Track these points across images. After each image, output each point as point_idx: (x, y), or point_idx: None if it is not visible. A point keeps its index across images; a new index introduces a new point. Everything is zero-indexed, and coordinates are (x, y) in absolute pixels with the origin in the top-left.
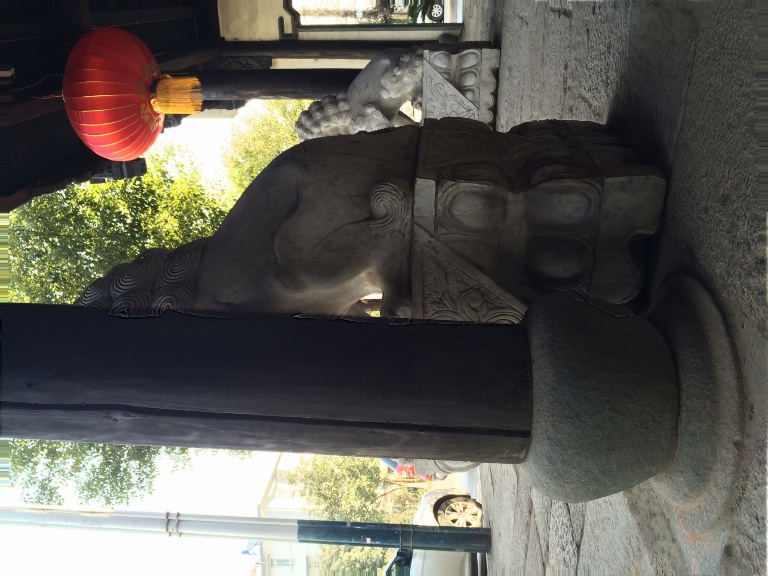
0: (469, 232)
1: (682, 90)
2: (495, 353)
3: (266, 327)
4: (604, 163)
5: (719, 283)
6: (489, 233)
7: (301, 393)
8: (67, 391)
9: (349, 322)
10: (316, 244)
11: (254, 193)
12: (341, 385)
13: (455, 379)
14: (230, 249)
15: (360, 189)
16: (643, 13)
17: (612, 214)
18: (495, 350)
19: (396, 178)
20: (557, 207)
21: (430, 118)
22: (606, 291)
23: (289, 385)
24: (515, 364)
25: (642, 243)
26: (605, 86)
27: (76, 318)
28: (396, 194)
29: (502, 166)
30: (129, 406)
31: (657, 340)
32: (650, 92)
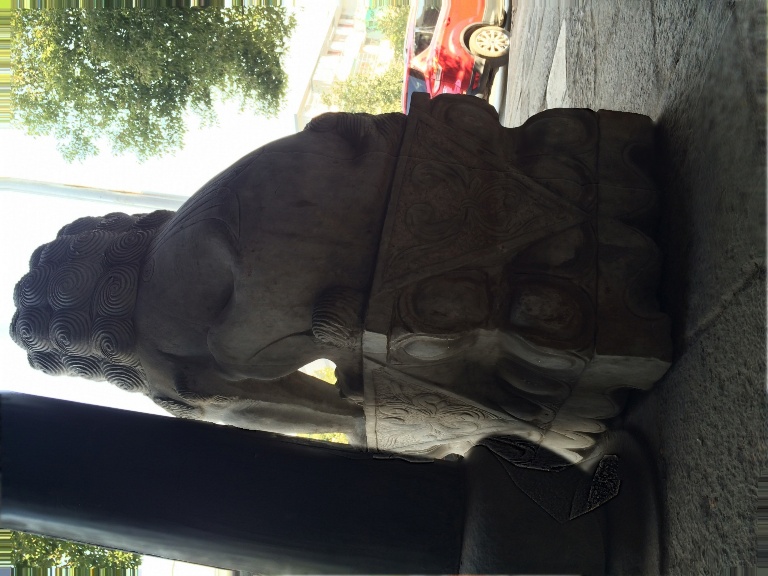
0: (428, 363)
1: (723, 293)
2: (425, 544)
3: (195, 477)
4: (608, 301)
5: (672, 551)
6: (453, 356)
7: (230, 558)
8: (7, 524)
9: (286, 454)
10: (253, 354)
11: (184, 251)
12: (268, 559)
13: (381, 568)
14: (165, 304)
15: (304, 295)
16: (733, 73)
17: (597, 374)
18: (426, 540)
19: (344, 307)
20: (533, 361)
21: (419, 104)
22: (578, 410)
23: (218, 551)
24: (444, 559)
25: (628, 390)
26: (672, 62)
27: (0, 443)
28: (341, 335)
29: (485, 264)
30: (69, 539)
31: (596, 553)
32: (700, 206)
